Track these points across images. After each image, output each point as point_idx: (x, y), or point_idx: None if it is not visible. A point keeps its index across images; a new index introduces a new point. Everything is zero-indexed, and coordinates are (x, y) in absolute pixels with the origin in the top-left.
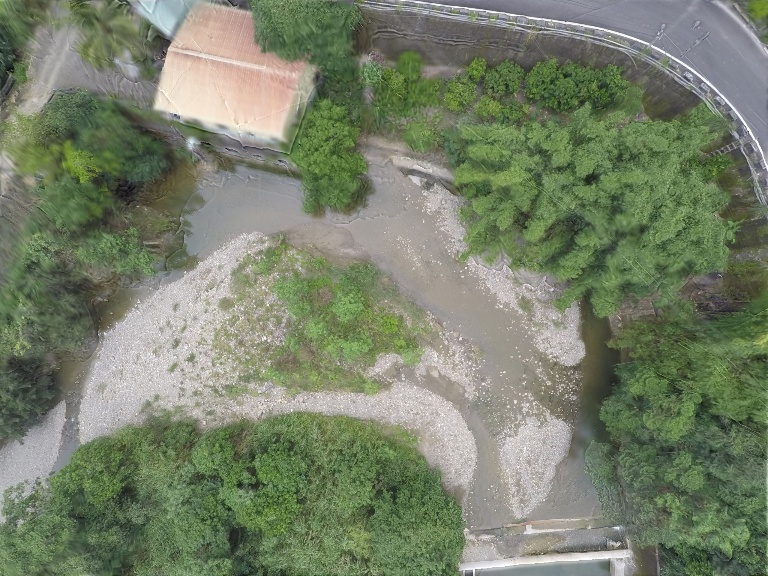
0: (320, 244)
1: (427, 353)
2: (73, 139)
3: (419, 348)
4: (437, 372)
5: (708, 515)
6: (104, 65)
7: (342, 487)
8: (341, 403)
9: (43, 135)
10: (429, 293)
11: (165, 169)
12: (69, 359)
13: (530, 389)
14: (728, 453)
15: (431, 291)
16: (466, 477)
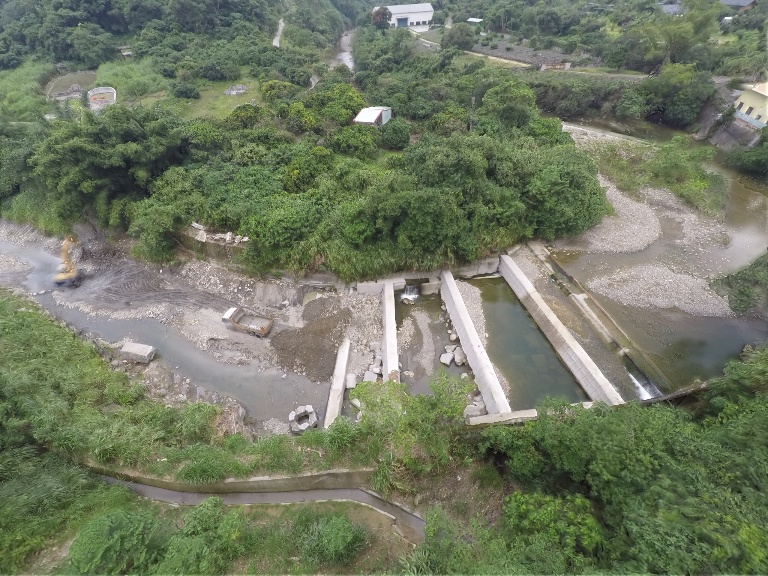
0: None
1: None
2: (702, 74)
3: (691, 211)
4: (682, 221)
5: None
6: (759, 64)
7: None
8: None
9: (696, 68)
10: (739, 216)
11: (692, 117)
12: (563, 102)
13: None
14: None
15: (742, 217)
16: (603, 245)
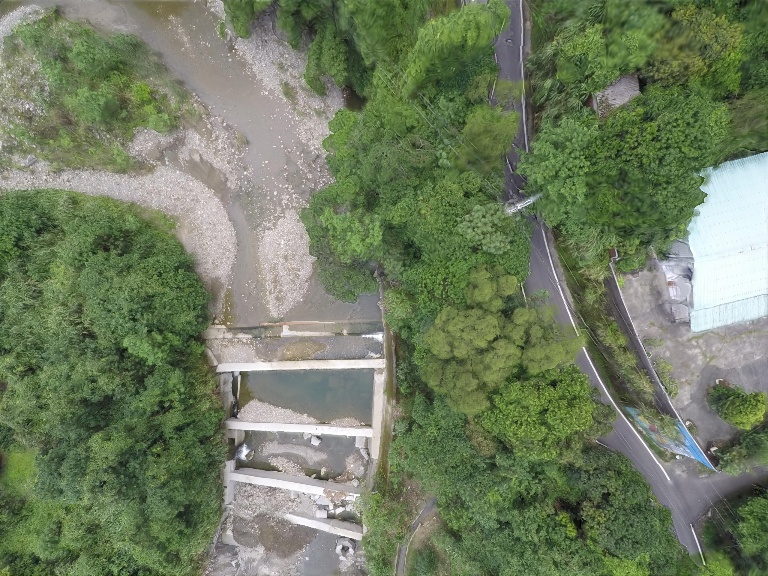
0: (94, 20)
1: (190, 136)
2: None
3: (181, 129)
4: (198, 155)
5: (347, 213)
6: None
7: (67, 239)
8: (105, 184)
9: None
10: (197, 76)
11: None
12: None
13: (291, 181)
14: (363, 142)
15: (199, 74)
16: (223, 269)
